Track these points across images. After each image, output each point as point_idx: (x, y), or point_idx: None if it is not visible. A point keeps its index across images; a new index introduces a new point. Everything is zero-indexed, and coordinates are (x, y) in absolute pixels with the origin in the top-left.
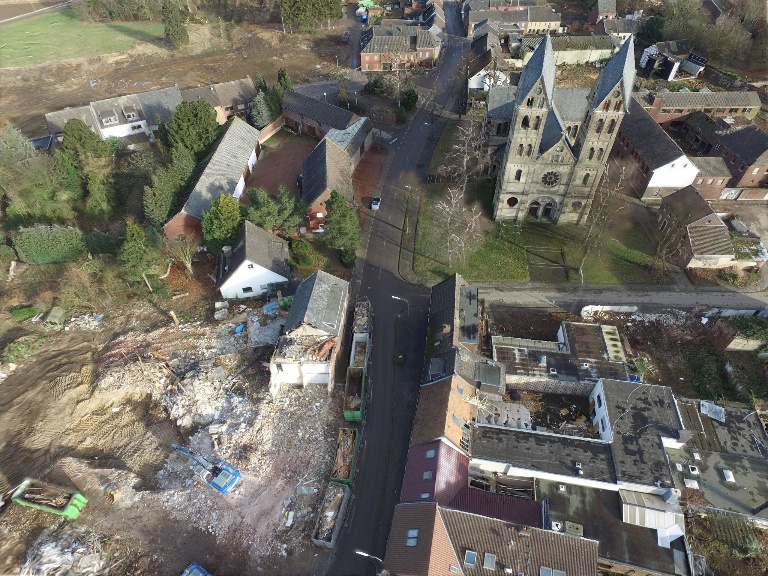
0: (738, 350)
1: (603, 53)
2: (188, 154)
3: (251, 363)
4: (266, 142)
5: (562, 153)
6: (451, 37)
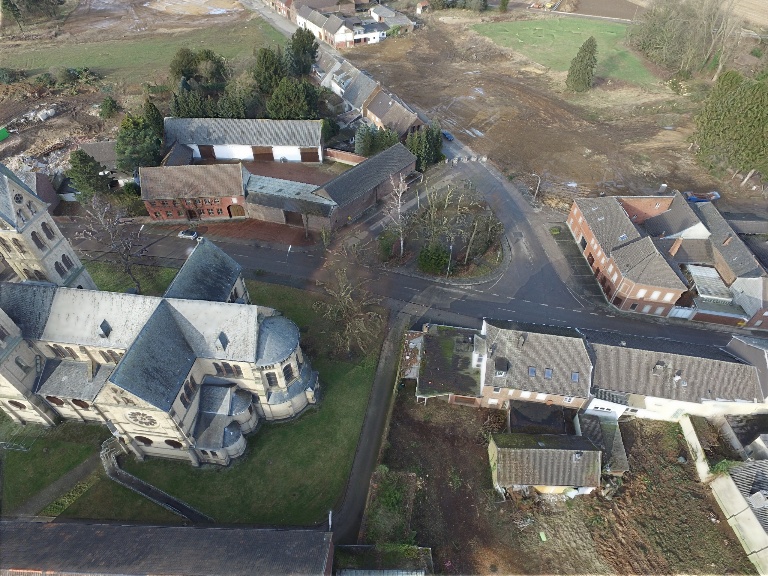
0: None
1: None
2: (244, 107)
3: None
4: (340, 164)
5: None
6: None
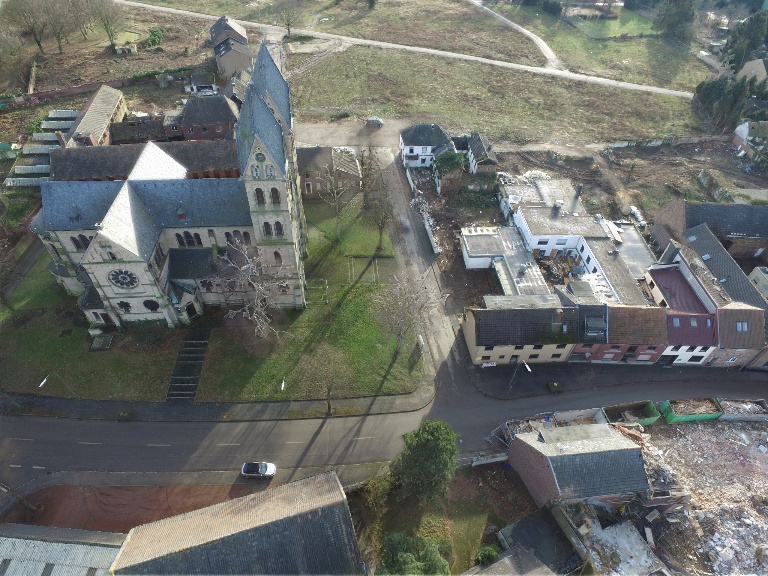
0: None
1: None
2: None
3: (664, 563)
4: None
5: None
6: None
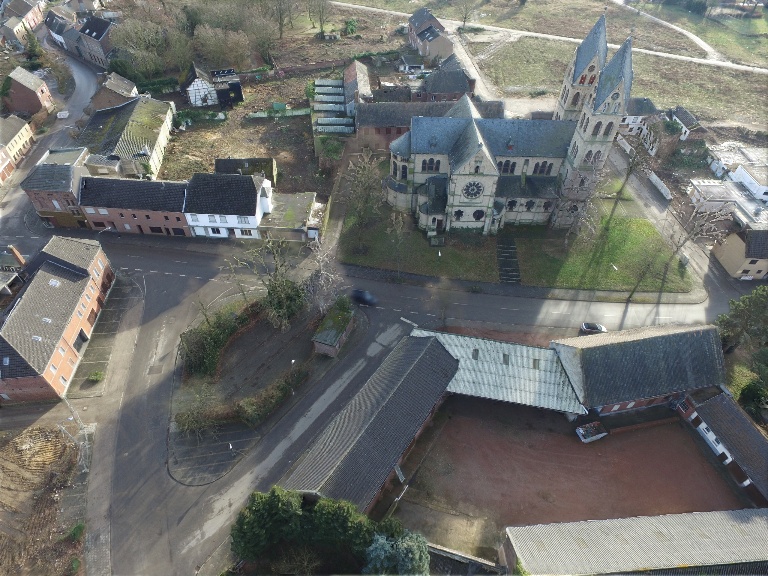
0: None
1: (168, 115)
2: None
3: None
4: None
5: None
6: None
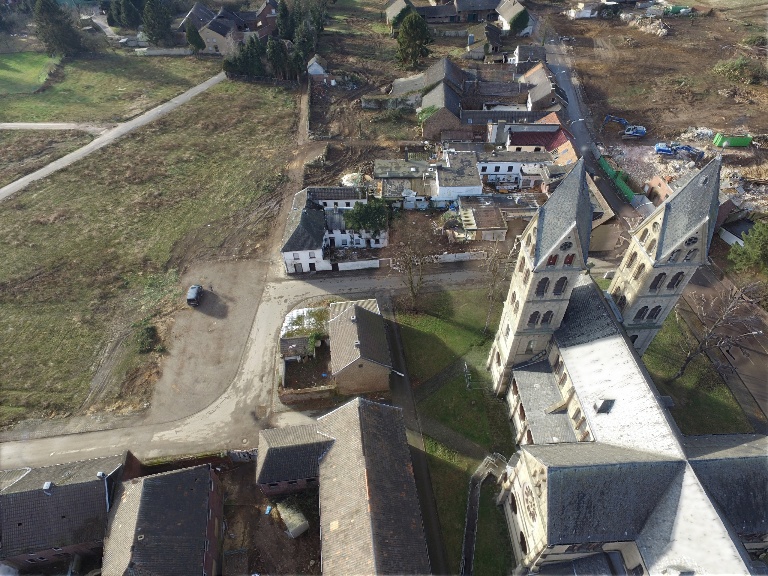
0: None
1: None
2: None
3: None
4: None
5: None
6: None
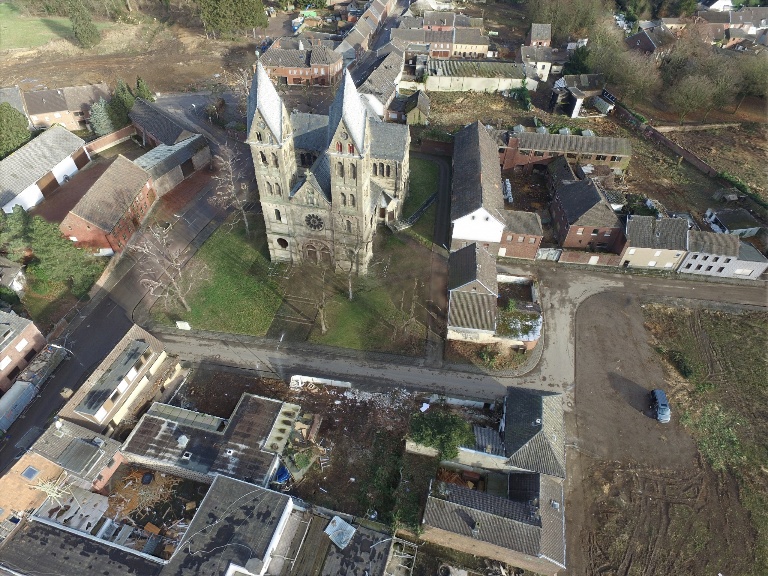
0: (419, 454)
1: (513, 82)
2: None
3: None
4: (103, 152)
5: (314, 195)
6: (373, 54)
